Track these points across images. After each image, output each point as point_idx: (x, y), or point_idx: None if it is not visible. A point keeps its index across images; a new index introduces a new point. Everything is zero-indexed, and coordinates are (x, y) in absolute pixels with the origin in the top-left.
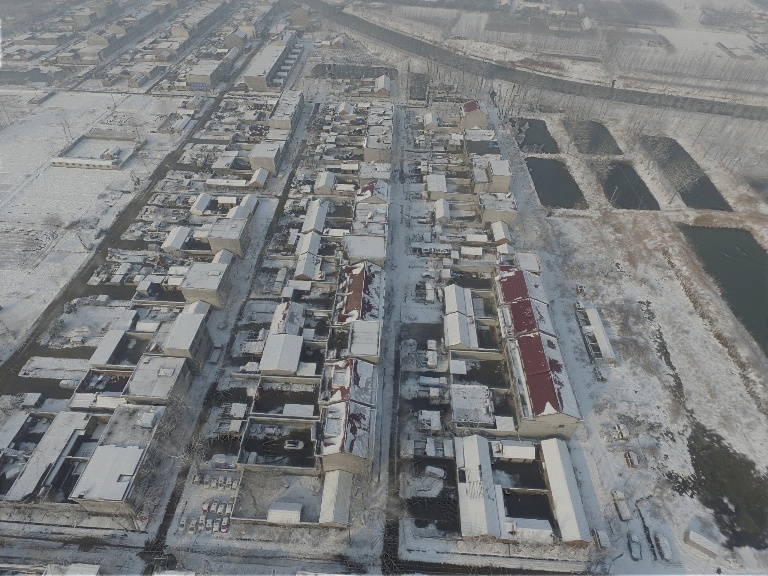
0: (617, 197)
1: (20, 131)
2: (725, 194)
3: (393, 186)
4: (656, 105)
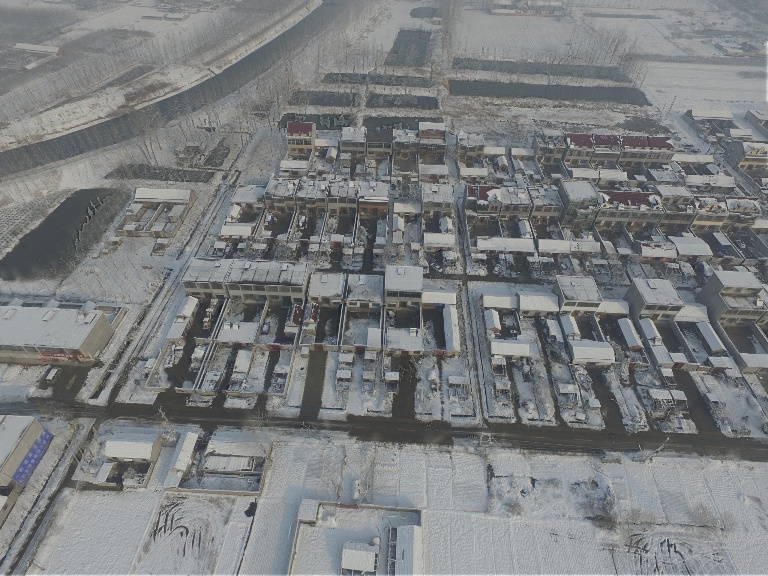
0: None
1: None
2: (412, 75)
3: None
4: (282, 62)
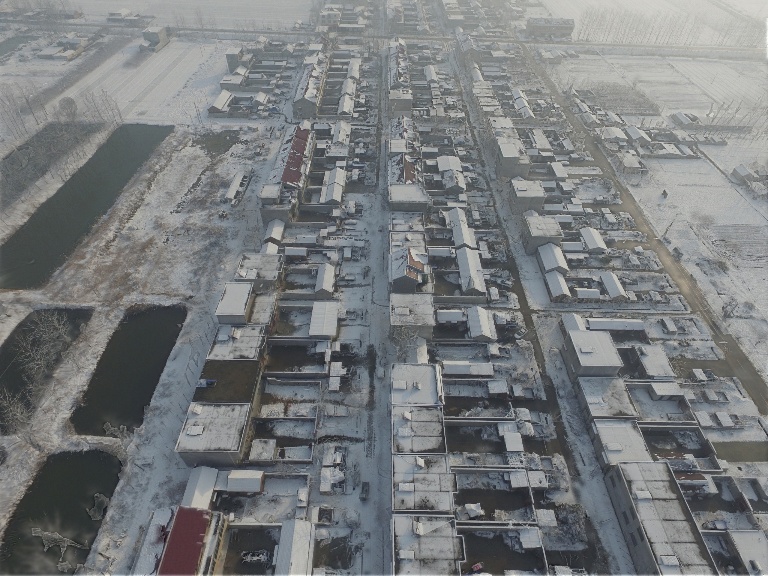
0: (69, 327)
1: None
2: None
3: (385, 334)
4: None
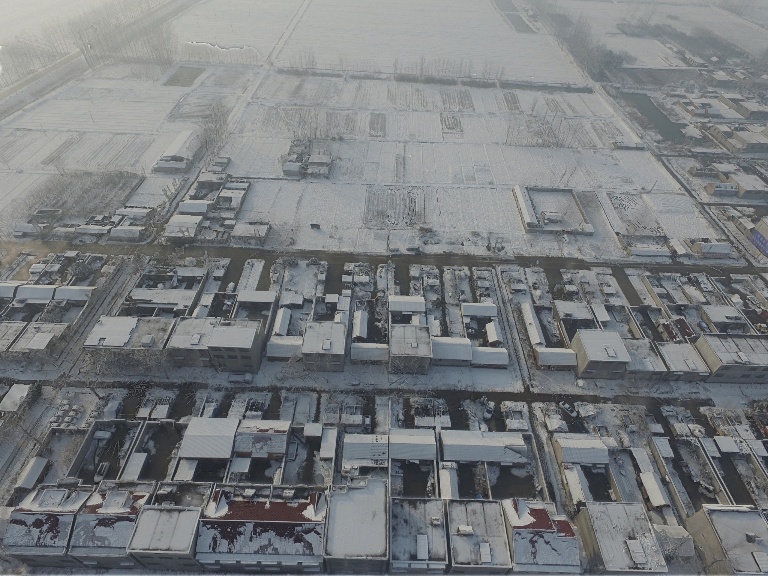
0: None
1: (560, 156)
2: None
3: None
4: None
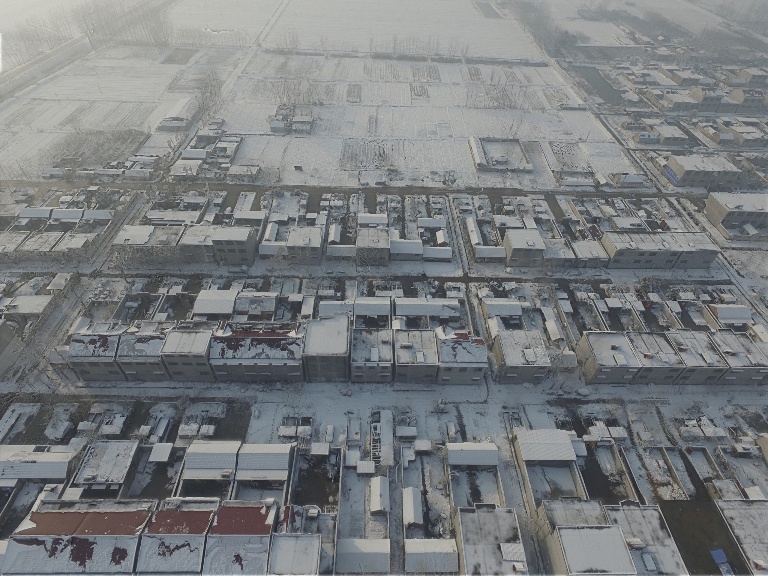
0: None
1: (513, 115)
2: None
3: (531, 388)
4: None
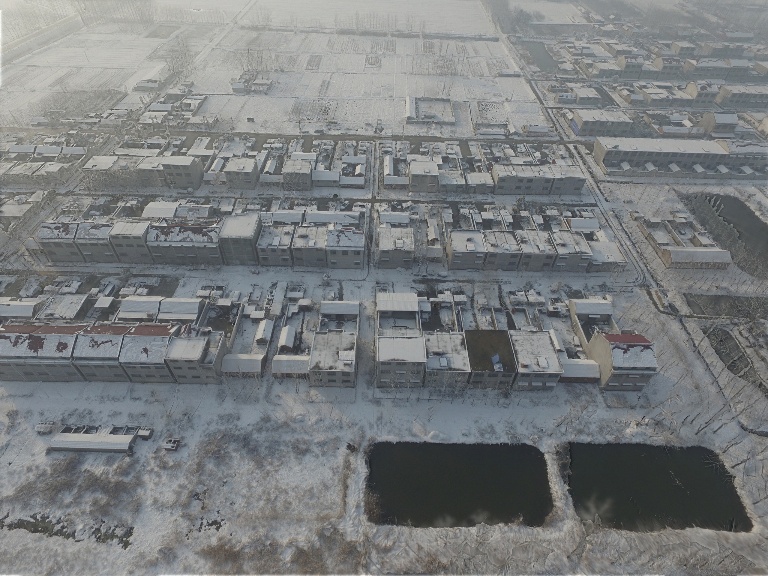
0: None
1: (452, 80)
2: None
3: (402, 271)
4: None
